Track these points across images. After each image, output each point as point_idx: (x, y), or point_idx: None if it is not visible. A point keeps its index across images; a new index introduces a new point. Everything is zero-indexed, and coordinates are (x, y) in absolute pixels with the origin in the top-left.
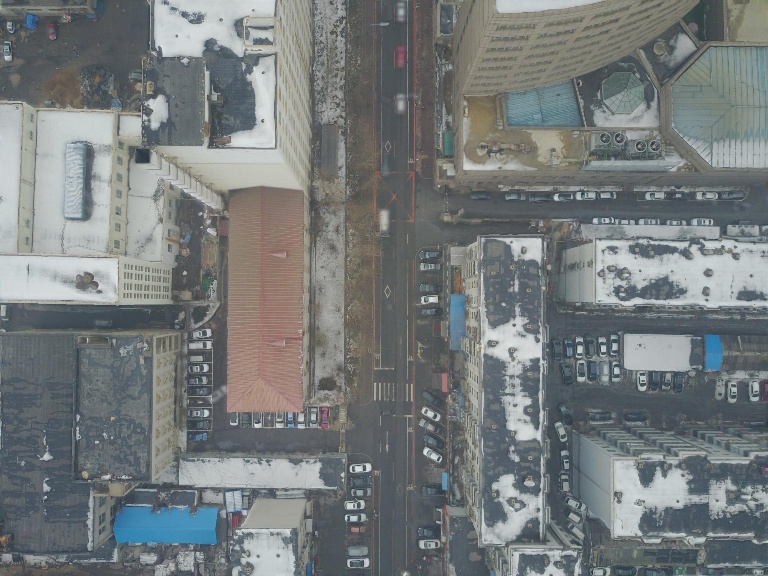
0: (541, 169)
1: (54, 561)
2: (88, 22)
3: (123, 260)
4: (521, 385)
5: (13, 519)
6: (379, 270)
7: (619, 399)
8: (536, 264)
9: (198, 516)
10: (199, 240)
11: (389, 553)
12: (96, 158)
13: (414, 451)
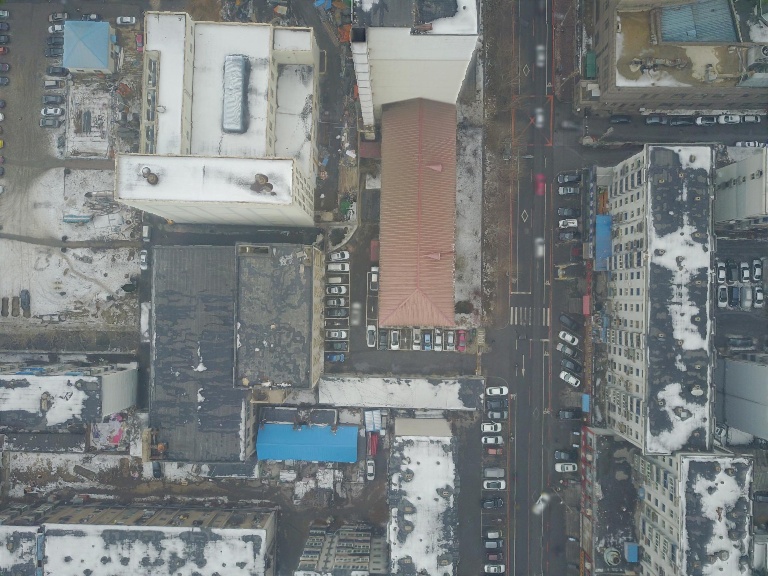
0: (695, 85)
1: (194, 478)
2: None
3: (296, 163)
4: (688, 294)
5: (167, 428)
6: (516, 194)
7: (761, 325)
8: (704, 173)
9: (339, 434)
10: (337, 163)
11: (525, 476)
12: (252, 71)
13: (551, 375)
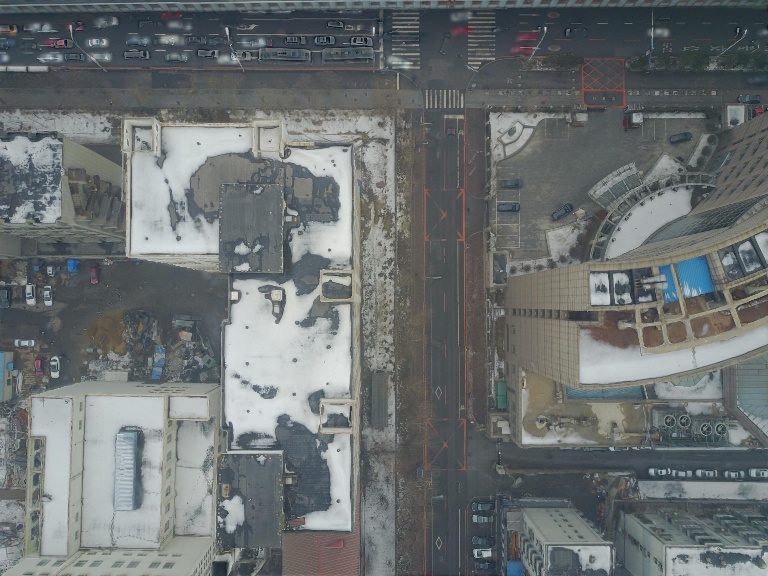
0: (602, 443)
1: None
2: (130, 265)
3: None
4: None
5: None
6: (430, 520)
7: None
8: (604, 573)
9: None
10: None
11: None
12: (146, 444)
13: None
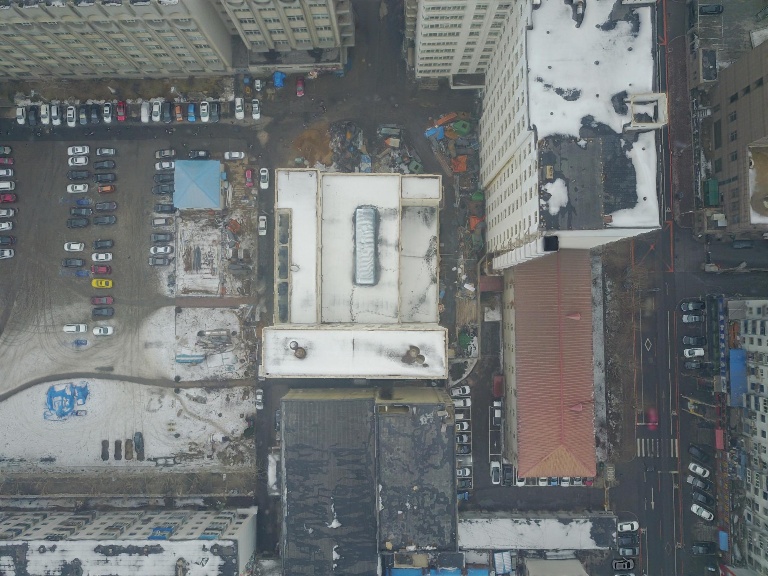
0: None
1: None
2: (334, 77)
3: None
4: None
5: None
6: (638, 323)
7: None
8: None
9: None
10: (454, 295)
11: None
12: (382, 222)
13: (681, 508)
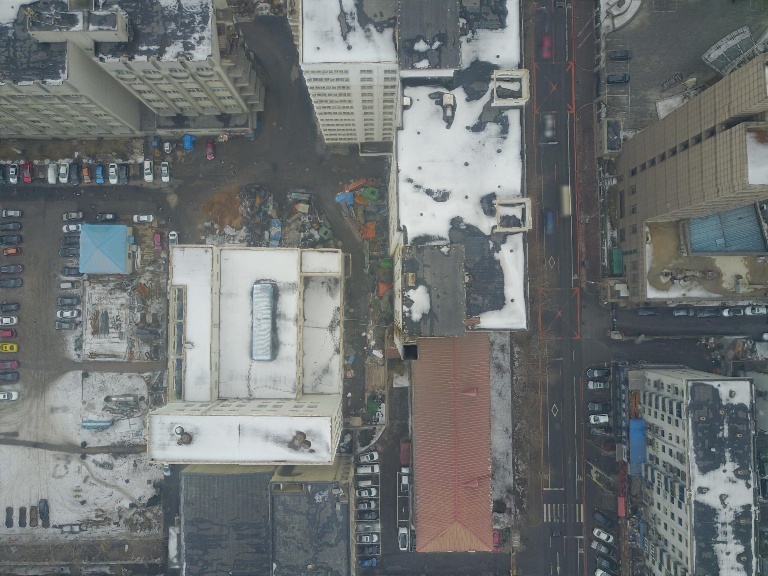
0: (726, 296)
1: None
2: (245, 141)
3: None
4: (733, 532)
5: None
6: (545, 388)
7: None
8: (745, 408)
9: None
10: (363, 361)
11: None
12: (280, 296)
13: (586, 573)
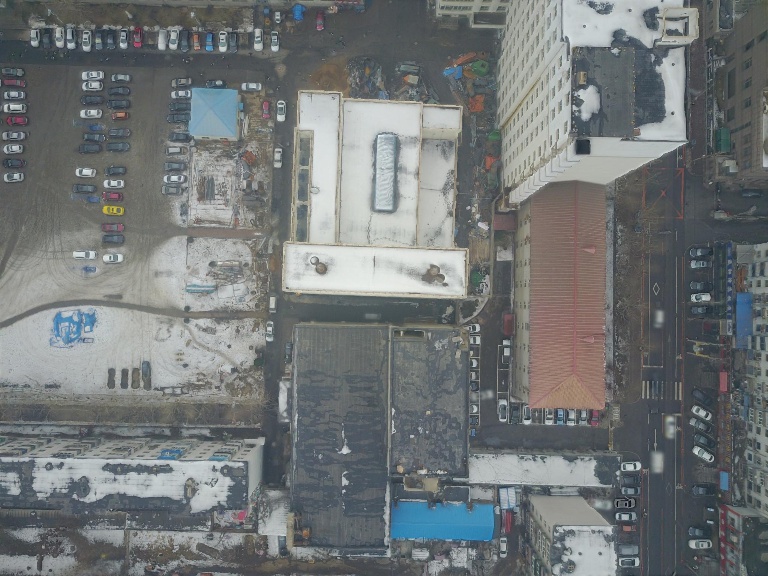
0: None
1: (320, 555)
2: (355, 13)
3: None
4: None
5: (310, 512)
6: (647, 267)
7: None
8: None
9: (474, 512)
10: (467, 234)
11: (658, 552)
12: (402, 150)
13: (683, 450)
